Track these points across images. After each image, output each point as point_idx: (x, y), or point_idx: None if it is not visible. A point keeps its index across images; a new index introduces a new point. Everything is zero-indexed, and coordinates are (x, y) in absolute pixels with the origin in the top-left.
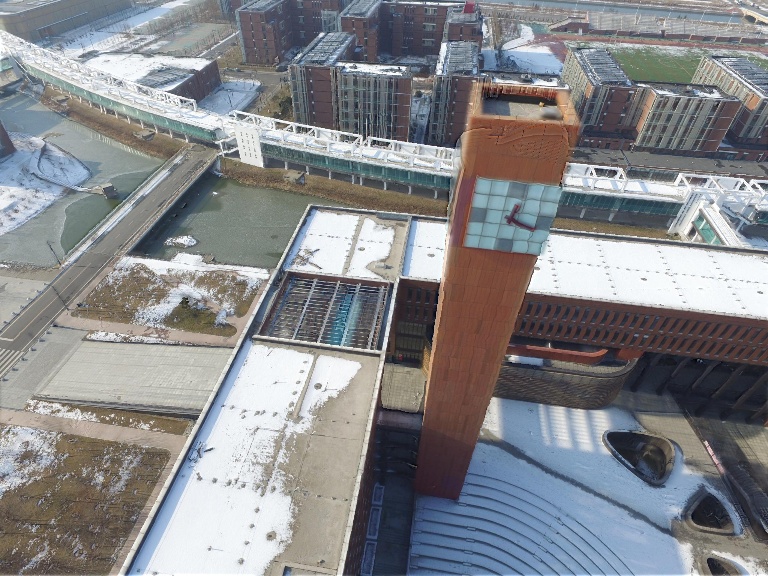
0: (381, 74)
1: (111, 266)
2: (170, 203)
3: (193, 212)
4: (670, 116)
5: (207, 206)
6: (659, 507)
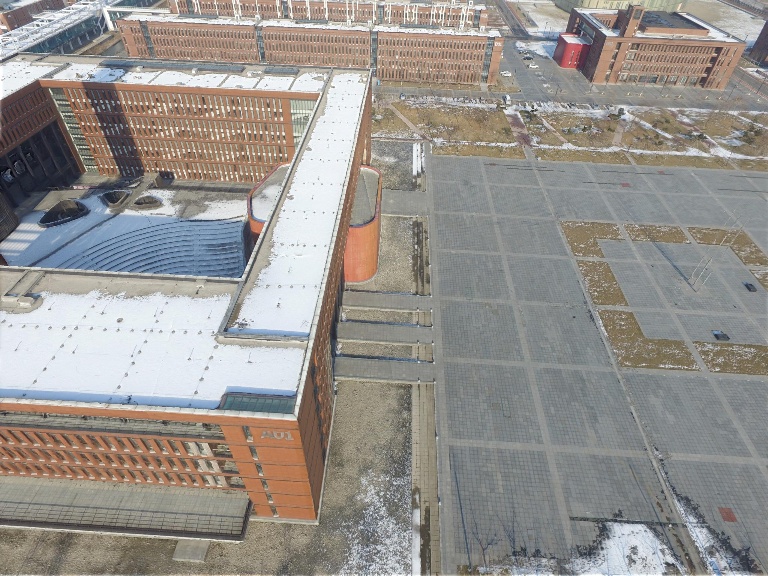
0: None
1: None
2: None
3: None
4: None
5: None
6: (100, 215)
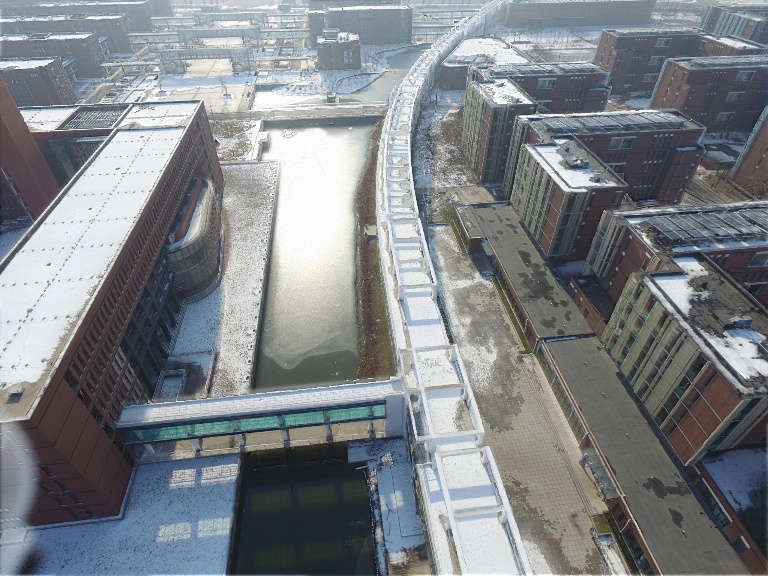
0: (487, 95)
1: (251, 120)
2: (322, 116)
3: (323, 128)
4: (640, 324)
5: (332, 130)
6: None
